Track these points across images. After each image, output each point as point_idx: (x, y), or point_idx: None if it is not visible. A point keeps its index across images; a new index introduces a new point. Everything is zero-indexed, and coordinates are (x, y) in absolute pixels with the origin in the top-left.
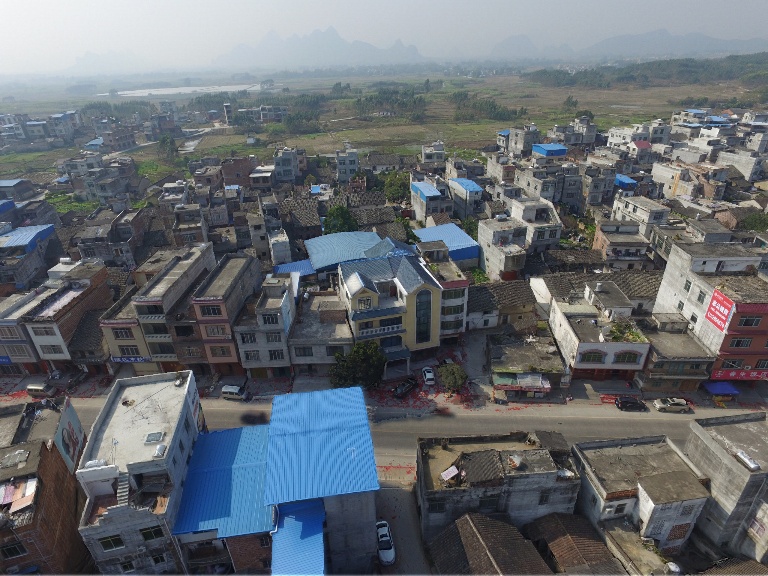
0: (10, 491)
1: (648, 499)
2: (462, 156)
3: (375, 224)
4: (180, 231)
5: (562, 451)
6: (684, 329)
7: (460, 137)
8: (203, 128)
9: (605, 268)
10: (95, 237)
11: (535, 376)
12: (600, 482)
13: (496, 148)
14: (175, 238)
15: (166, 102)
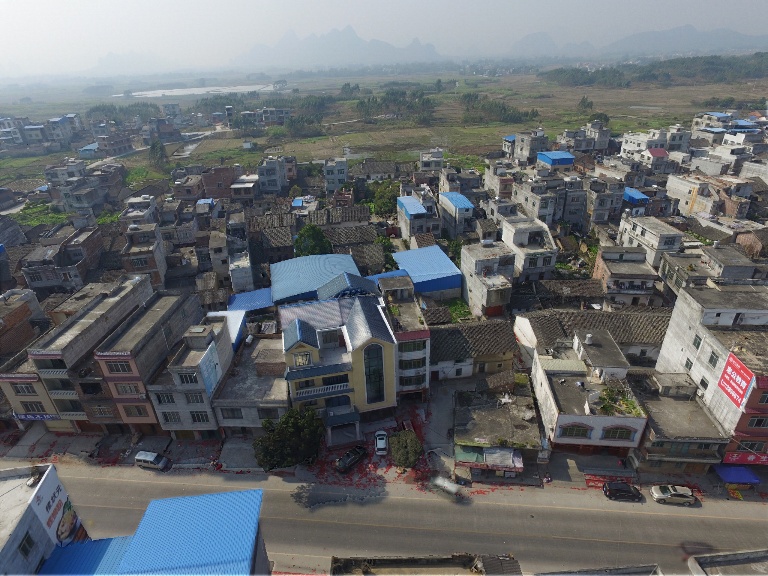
0: None
1: None
2: (464, 163)
3: (354, 244)
4: (129, 255)
5: None
6: (692, 395)
7: (466, 141)
8: (203, 131)
9: (605, 303)
10: (42, 260)
11: (505, 451)
12: None
13: (501, 154)
14: (124, 263)
15: (169, 104)
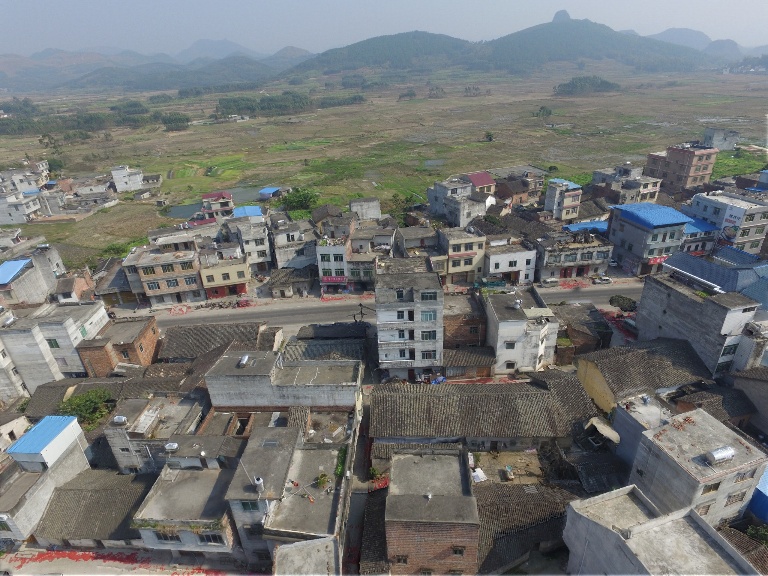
0: None
1: None
2: None
3: None
4: None
5: None
6: None
7: None
8: None
9: None
10: None
11: None
12: (525, 245)
13: None
14: None
15: None
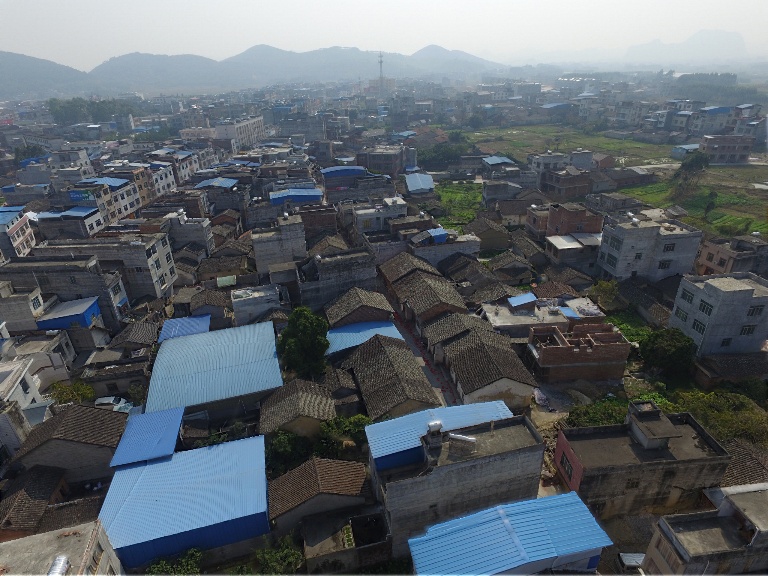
0: None
1: None
2: None
3: None
4: None
5: None
6: None
7: None
8: None
9: None
10: None
11: None
12: None
13: None
14: None
15: None
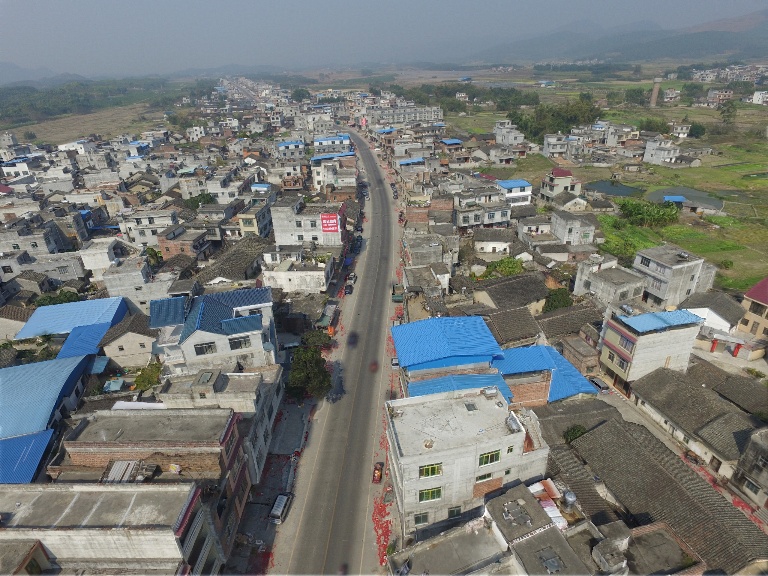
0: (545, 503)
1: (444, 276)
2: None
3: None
4: None
5: (421, 287)
6: (314, 247)
7: None
8: None
9: (201, 261)
10: None
11: (327, 306)
12: None
13: None
14: None
15: None
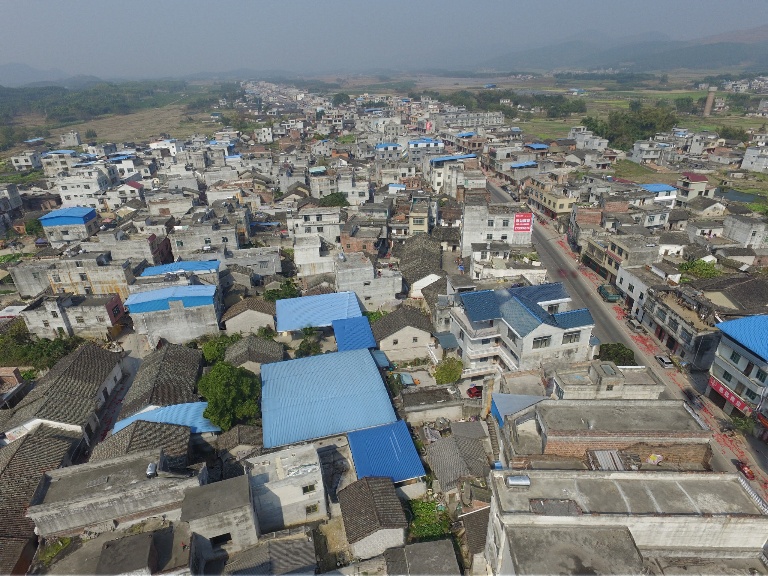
0: None
1: (676, 276)
2: None
3: None
4: None
5: None
6: None
7: None
8: None
9: (382, 259)
10: None
11: None
12: None
13: None
14: None
15: None
